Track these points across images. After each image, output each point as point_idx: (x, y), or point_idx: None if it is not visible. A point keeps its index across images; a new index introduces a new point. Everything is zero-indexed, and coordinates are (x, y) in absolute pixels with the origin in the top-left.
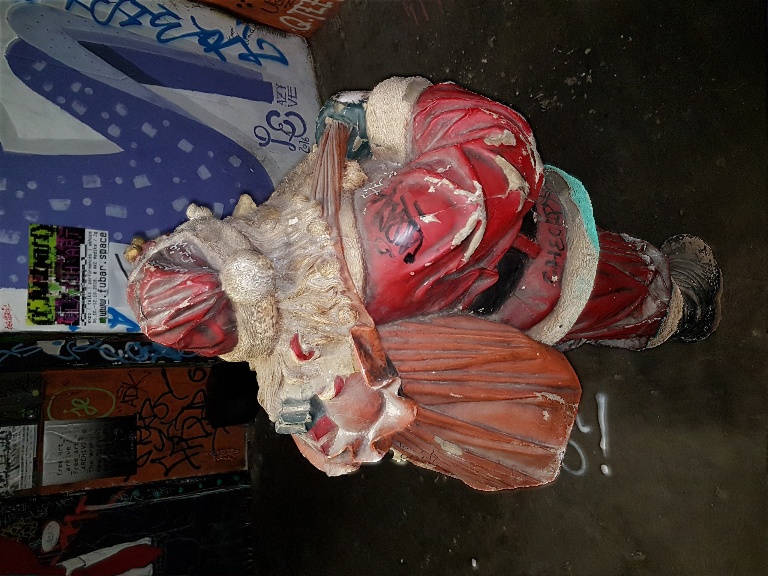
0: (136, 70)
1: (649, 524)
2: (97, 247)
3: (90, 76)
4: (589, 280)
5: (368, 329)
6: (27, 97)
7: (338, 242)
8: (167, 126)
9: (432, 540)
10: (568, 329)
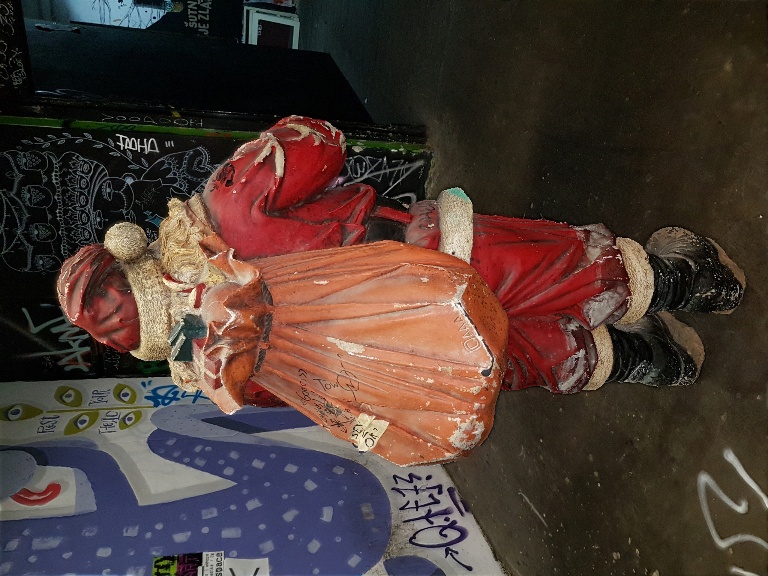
0: (246, 426)
1: None
2: (213, 567)
3: (210, 439)
4: (462, 213)
5: (210, 236)
6: (161, 464)
7: None
8: (274, 458)
9: None
10: (464, 254)
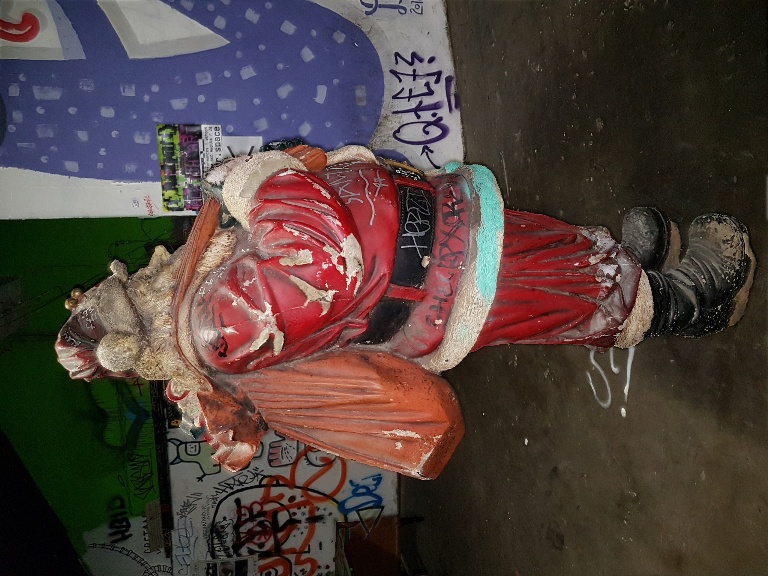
0: None
1: (646, 475)
2: (213, 141)
3: None
4: (473, 326)
5: (208, 393)
6: (142, 1)
7: (174, 333)
8: (269, 8)
9: (503, 410)
10: (457, 362)
